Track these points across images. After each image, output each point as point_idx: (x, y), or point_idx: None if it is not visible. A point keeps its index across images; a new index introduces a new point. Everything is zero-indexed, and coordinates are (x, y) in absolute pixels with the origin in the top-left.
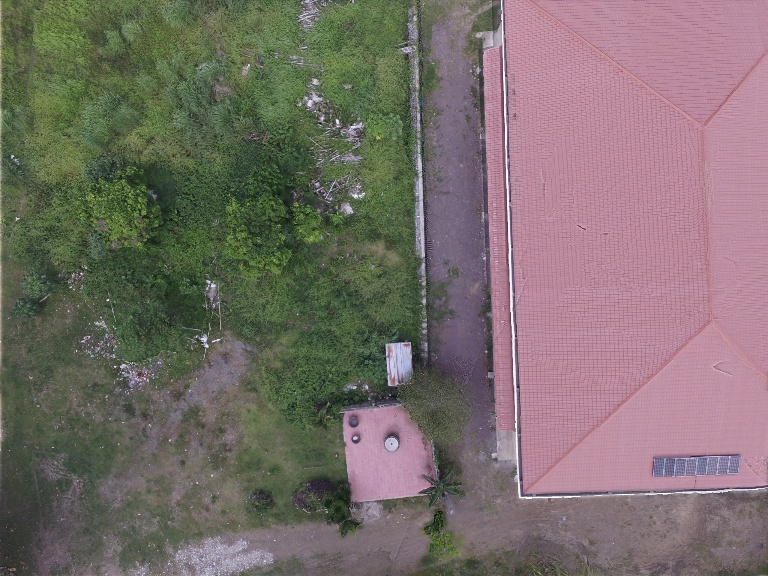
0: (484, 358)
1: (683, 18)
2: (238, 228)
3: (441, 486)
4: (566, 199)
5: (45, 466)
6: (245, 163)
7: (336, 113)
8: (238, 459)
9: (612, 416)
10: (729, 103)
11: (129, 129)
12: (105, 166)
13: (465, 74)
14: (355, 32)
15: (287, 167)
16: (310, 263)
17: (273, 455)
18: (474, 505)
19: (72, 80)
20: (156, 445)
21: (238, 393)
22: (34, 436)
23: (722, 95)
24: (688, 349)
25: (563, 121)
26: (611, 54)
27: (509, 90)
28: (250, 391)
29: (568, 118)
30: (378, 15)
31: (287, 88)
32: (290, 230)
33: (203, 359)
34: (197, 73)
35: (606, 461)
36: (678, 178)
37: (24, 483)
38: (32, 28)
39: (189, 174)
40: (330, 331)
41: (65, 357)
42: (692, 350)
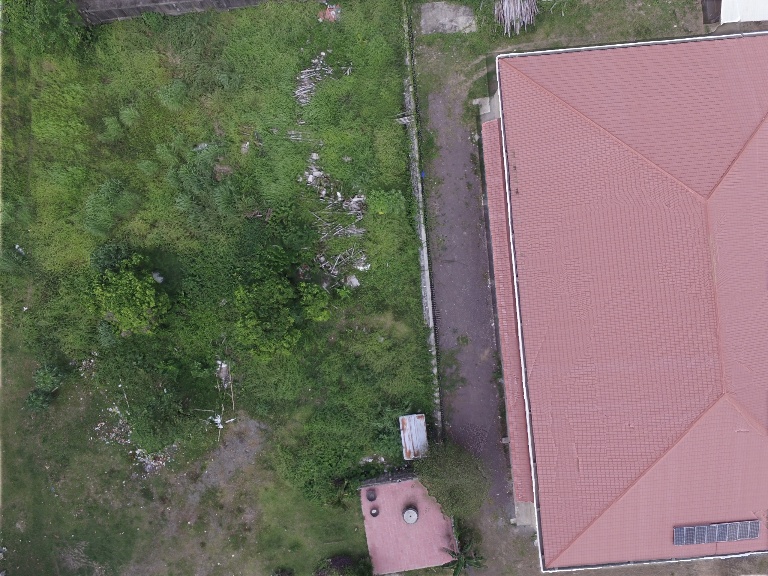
0: (498, 424)
1: (679, 87)
2: (247, 315)
3: (462, 559)
4: (572, 266)
5: (66, 555)
6: (249, 241)
7: (337, 186)
8: (258, 538)
9: (630, 489)
10: (730, 173)
11: (132, 213)
12: (110, 254)
13: (464, 141)
14: (352, 104)
15: (292, 246)
16: (319, 338)
17: (293, 532)
18: (496, 571)
19: (72, 167)
20: (176, 528)
21: (254, 472)
22: (54, 525)
23: (723, 165)
24: (703, 421)
25: (566, 196)
26: (610, 128)
27: (510, 166)
28: (266, 469)
29: (570, 193)
30: (374, 87)
31: (287, 165)
32: (299, 312)
33: (218, 440)
34: (197, 156)
35: (626, 532)
36: (681, 235)
37: (46, 573)
38: (30, 117)
39: (194, 255)
40: (343, 406)
41: (80, 445)
42: (707, 422)
